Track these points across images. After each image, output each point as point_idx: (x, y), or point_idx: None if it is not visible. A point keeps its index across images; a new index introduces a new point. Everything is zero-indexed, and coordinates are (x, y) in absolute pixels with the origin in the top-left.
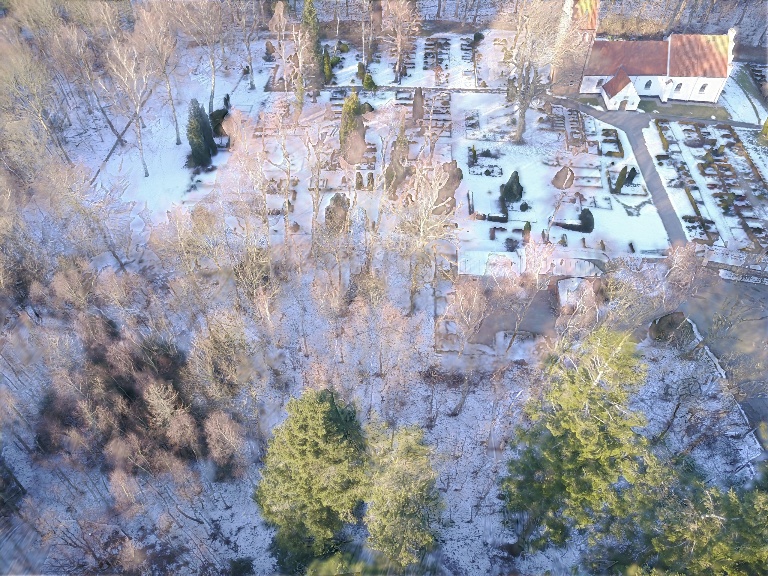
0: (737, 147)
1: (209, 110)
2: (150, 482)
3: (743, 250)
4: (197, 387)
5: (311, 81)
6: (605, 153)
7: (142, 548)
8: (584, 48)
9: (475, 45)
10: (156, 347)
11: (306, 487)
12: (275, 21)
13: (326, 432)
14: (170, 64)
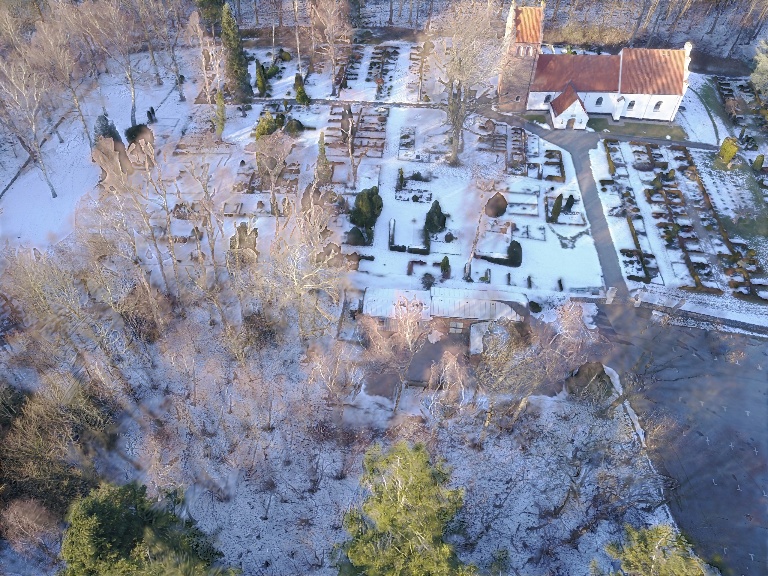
0: (690, 171)
1: (132, 124)
2: None
3: (682, 288)
4: (14, 464)
5: (236, 95)
6: (545, 177)
7: None
8: (512, 68)
9: (425, 54)
10: None
11: None
12: (190, 32)
13: (94, 552)
14: (75, 78)
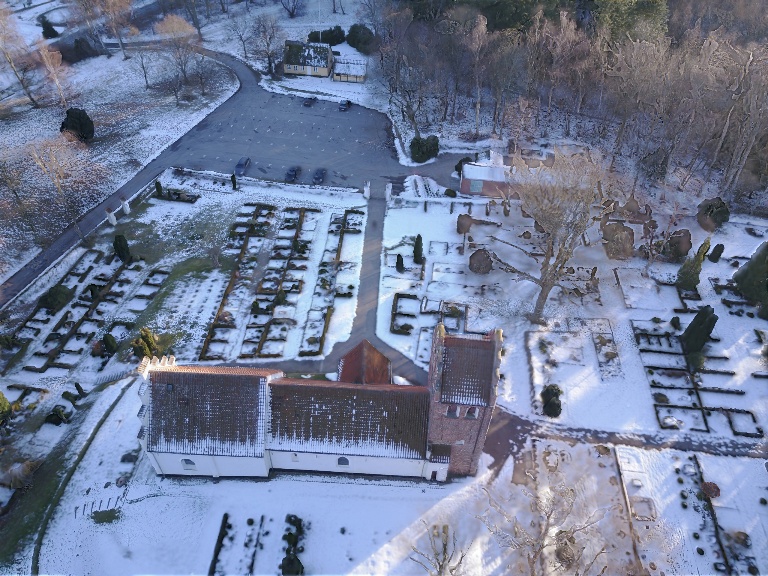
0: None
1: None
2: None
3: (318, 211)
4: None
5: None
6: (418, 300)
7: None
8: None
9: None
10: None
11: None
12: None
13: None
14: None
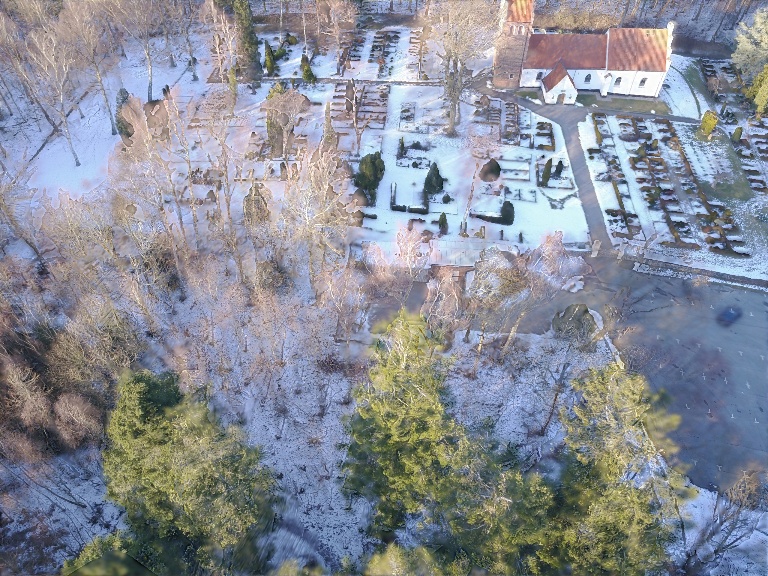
0: (673, 141)
1: (148, 101)
2: (4, 463)
3: (663, 244)
4: (61, 370)
5: (247, 72)
6: (537, 146)
7: (22, 530)
8: None
9: (424, 38)
10: (32, 331)
11: (136, 468)
12: (205, 12)
13: (143, 412)
14: (98, 54)
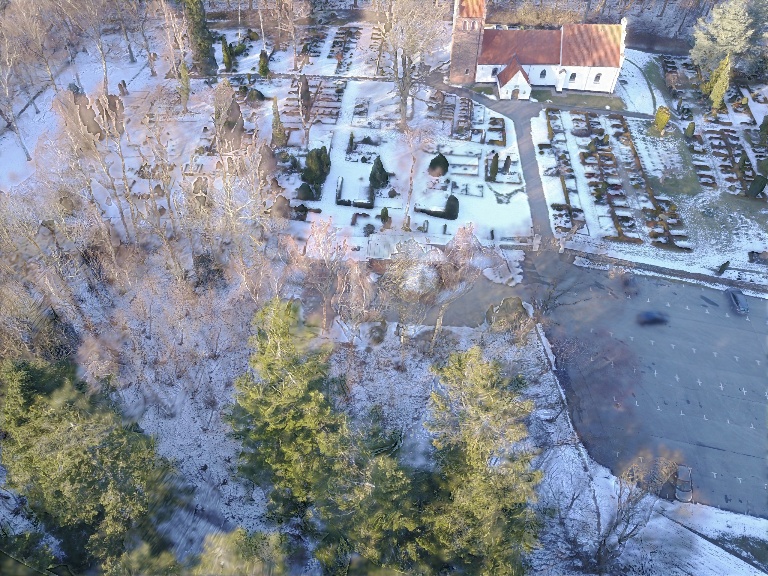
0: (625, 137)
1: None
2: None
3: (606, 238)
4: None
5: (201, 68)
6: (488, 141)
7: None
8: None
9: None
10: None
11: (27, 456)
12: (155, 6)
13: (26, 400)
14: (47, 48)
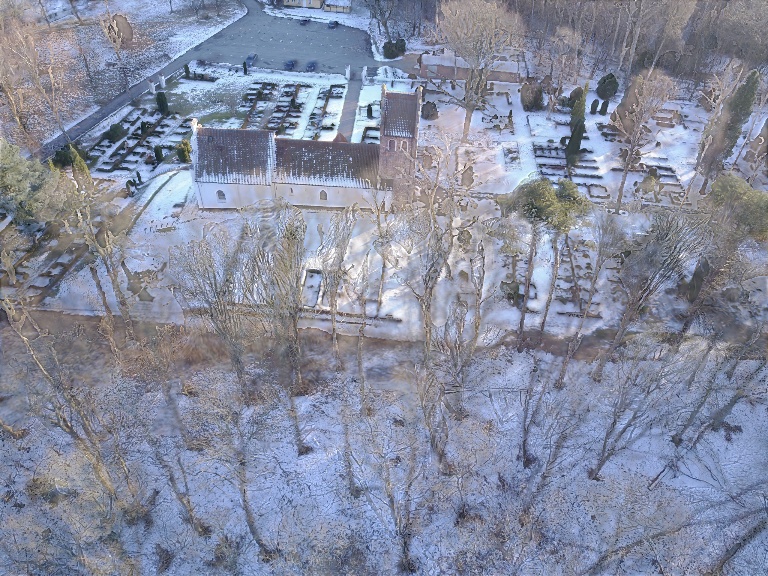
0: None
1: None
2: None
3: (310, 87)
4: None
5: None
6: None
7: None
8: None
9: None
10: None
11: None
12: None
13: None
14: None
